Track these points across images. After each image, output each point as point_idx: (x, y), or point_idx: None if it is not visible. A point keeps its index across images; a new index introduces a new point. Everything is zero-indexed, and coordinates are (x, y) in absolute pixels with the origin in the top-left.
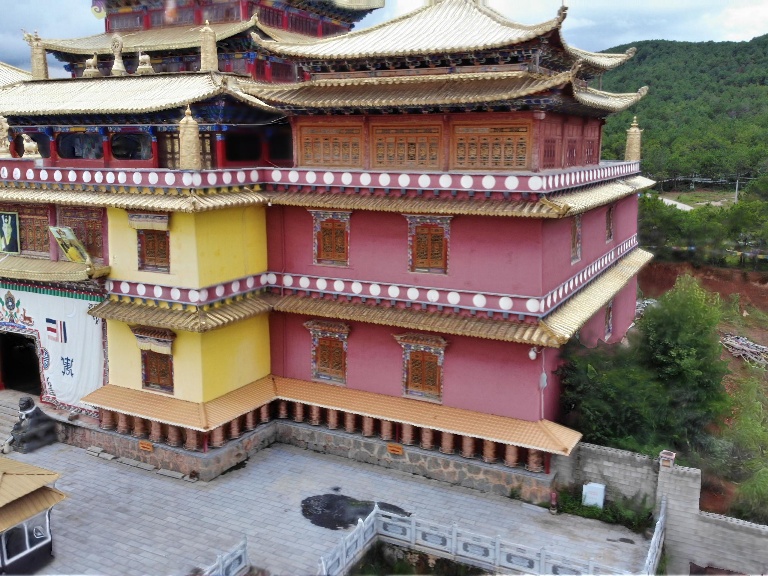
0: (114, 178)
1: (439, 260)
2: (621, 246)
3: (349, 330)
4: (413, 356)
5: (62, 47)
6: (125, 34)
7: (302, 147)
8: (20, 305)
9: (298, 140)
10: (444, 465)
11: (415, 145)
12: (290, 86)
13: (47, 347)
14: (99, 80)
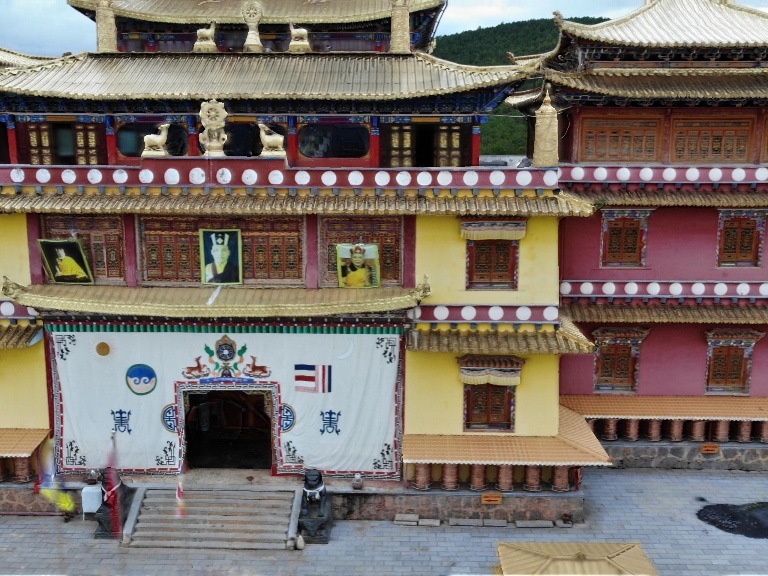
0: (431, 179)
1: (748, 253)
2: None
3: (648, 334)
4: (716, 352)
5: (124, 10)
6: None
7: (583, 141)
8: (246, 352)
9: (579, 133)
10: (763, 455)
11: (721, 139)
12: (576, 74)
13: (291, 402)
14: (234, 57)
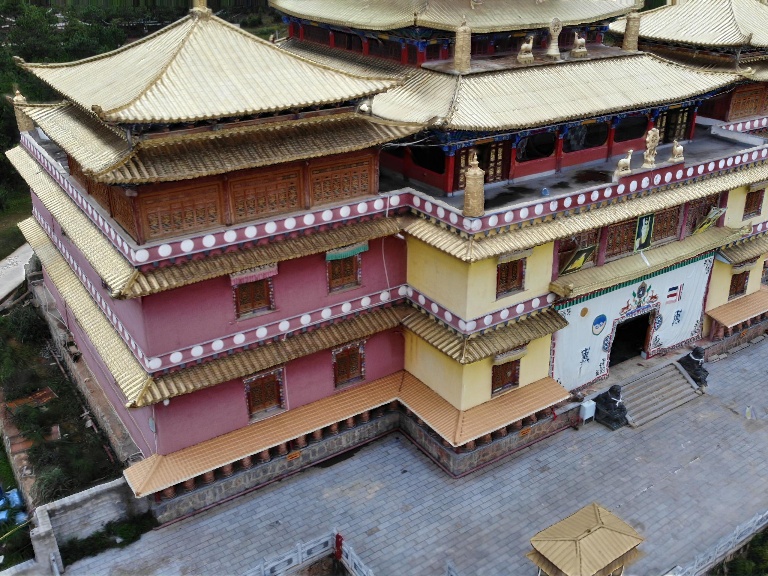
0: (740, 160)
1: None
2: None
3: None
4: None
5: (452, 26)
6: (464, 2)
7: None
8: None
9: None
10: None
11: None
12: None
13: (662, 312)
14: (554, 67)
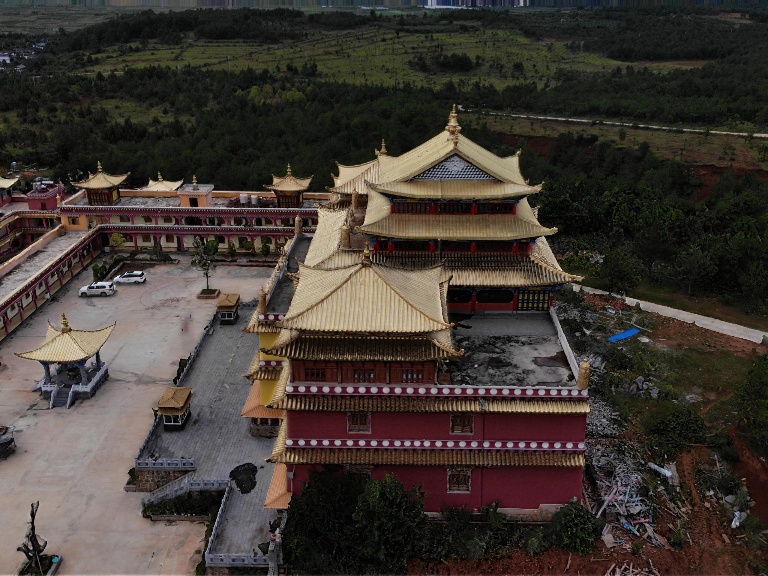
0: None
1: None
2: (509, 443)
3: None
4: None
5: None
6: None
7: None
8: None
9: None
10: None
11: None
12: None
13: None
14: None
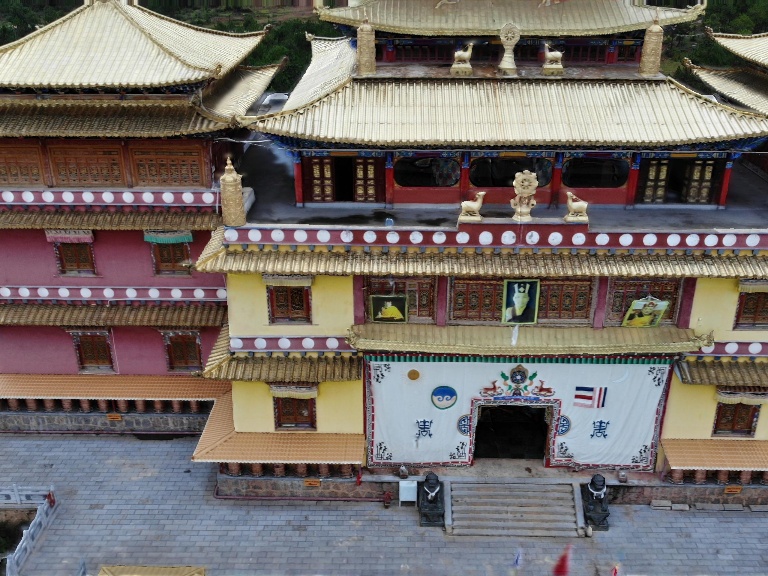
0: (717, 241)
1: None
2: None
3: None
4: None
5: (375, 24)
6: None
7: None
8: (536, 377)
9: None
10: None
11: None
12: None
13: (568, 414)
14: (494, 83)
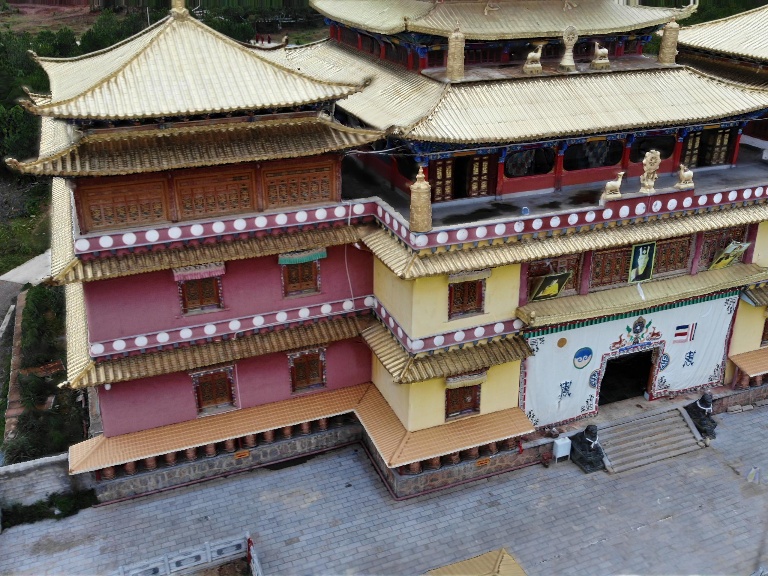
0: None
1: None
2: None
3: None
4: None
5: (451, 32)
6: (478, 7)
7: None
8: (651, 325)
9: None
10: None
11: None
12: None
13: (669, 351)
14: (564, 79)
